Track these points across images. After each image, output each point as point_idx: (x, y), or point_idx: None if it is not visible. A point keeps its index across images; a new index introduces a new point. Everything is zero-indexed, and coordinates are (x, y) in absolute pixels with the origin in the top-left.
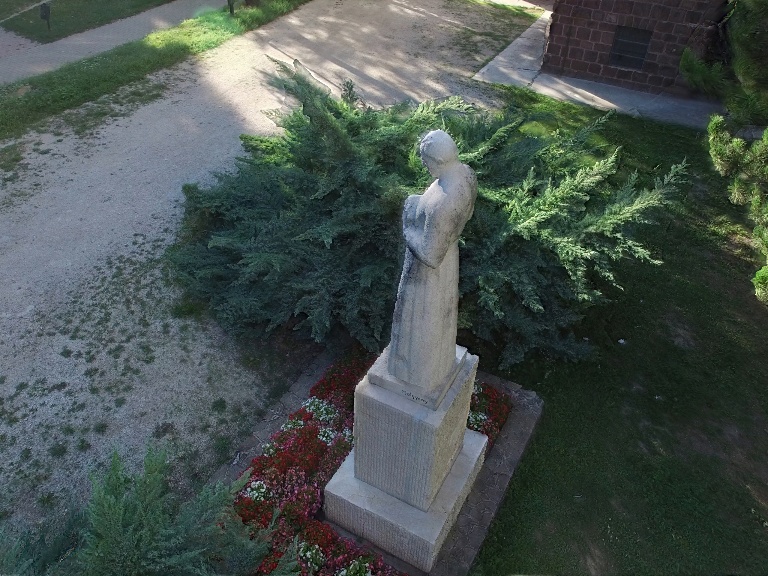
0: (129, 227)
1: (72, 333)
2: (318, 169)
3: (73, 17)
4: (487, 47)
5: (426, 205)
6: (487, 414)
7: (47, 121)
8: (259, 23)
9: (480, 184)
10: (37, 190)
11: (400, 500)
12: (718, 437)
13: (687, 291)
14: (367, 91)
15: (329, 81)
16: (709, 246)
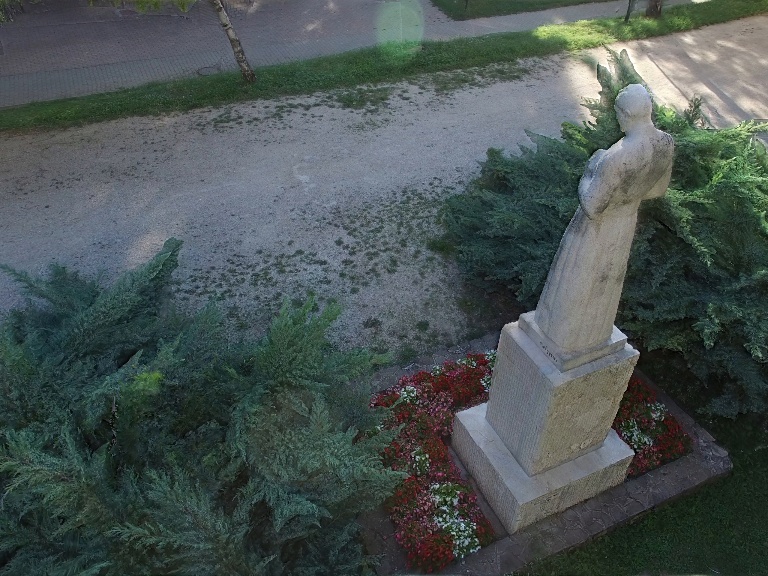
0: (434, 171)
1: (351, 230)
2: None
3: (488, 4)
4: None
5: None
6: (656, 443)
7: (420, 76)
8: (648, 34)
9: None
10: (385, 124)
11: (512, 455)
12: None
13: None
14: (726, 120)
15: None
16: None
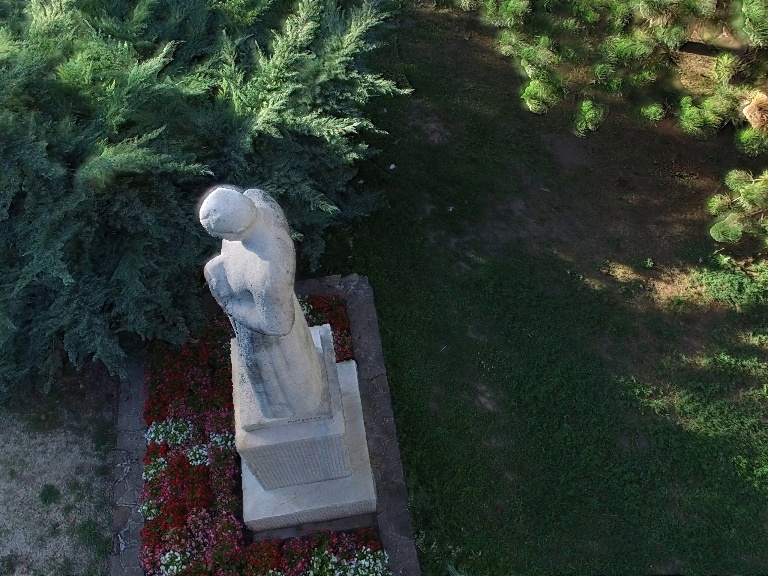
0: None
1: None
2: None
3: None
4: None
5: (246, 282)
6: None
7: None
8: None
9: (172, 74)
10: None
11: (321, 482)
12: (513, 219)
13: (417, 77)
14: None
15: None
16: (408, 12)
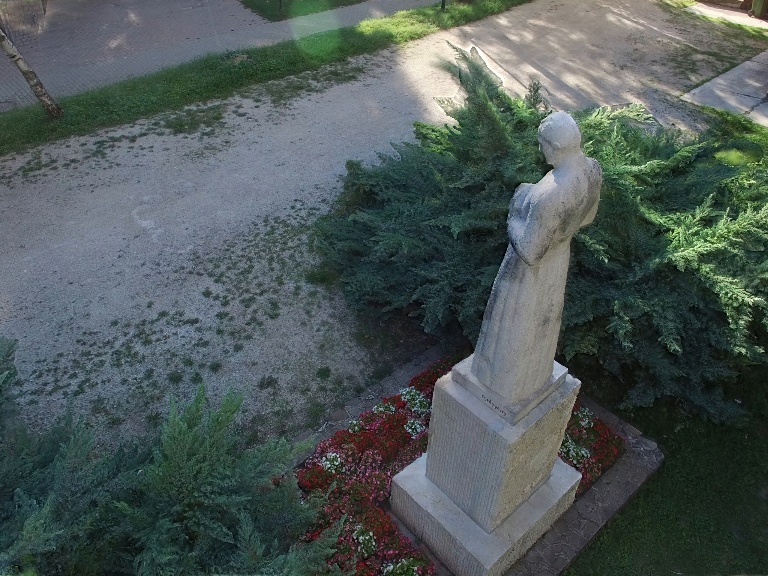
0: (292, 192)
1: (217, 276)
2: (474, 161)
3: (302, 1)
4: (706, 67)
5: (533, 193)
6: (592, 452)
7: (252, 88)
8: (466, 20)
9: (646, 204)
10: (226, 147)
11: (465, 512)
12: None
13: None
14: (558, 97)
15: (521, 83)
16: None
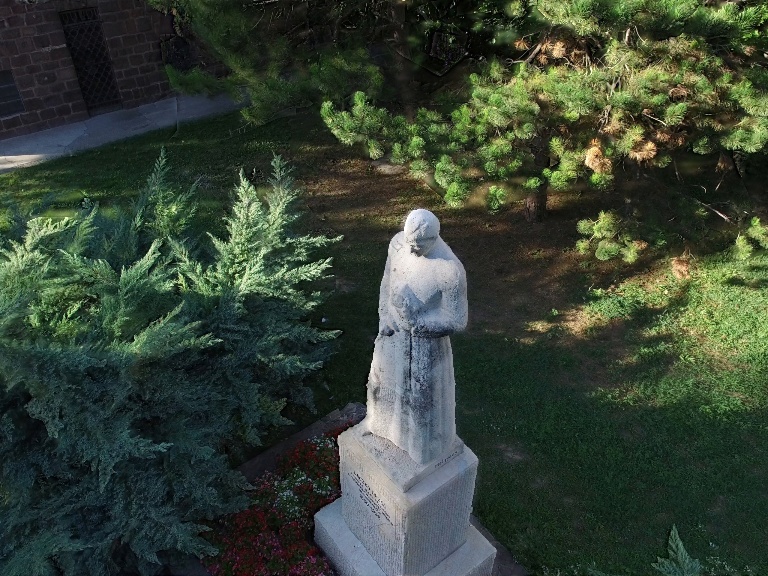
0: None
1: None
2: None
3: None
4: None
5: (439, 284)
6: None
7: None
8: None
9: None
10: None
11: (445, 559)
12: None
13: None
14: None
15: None
16: None
